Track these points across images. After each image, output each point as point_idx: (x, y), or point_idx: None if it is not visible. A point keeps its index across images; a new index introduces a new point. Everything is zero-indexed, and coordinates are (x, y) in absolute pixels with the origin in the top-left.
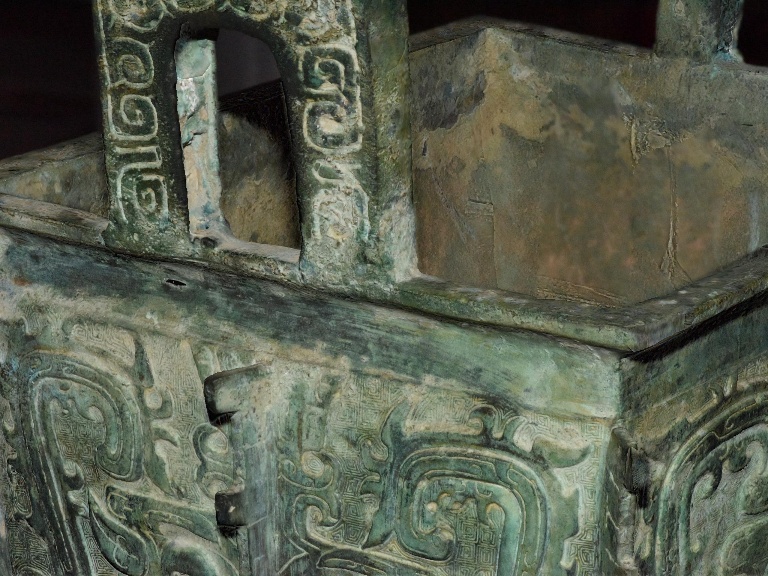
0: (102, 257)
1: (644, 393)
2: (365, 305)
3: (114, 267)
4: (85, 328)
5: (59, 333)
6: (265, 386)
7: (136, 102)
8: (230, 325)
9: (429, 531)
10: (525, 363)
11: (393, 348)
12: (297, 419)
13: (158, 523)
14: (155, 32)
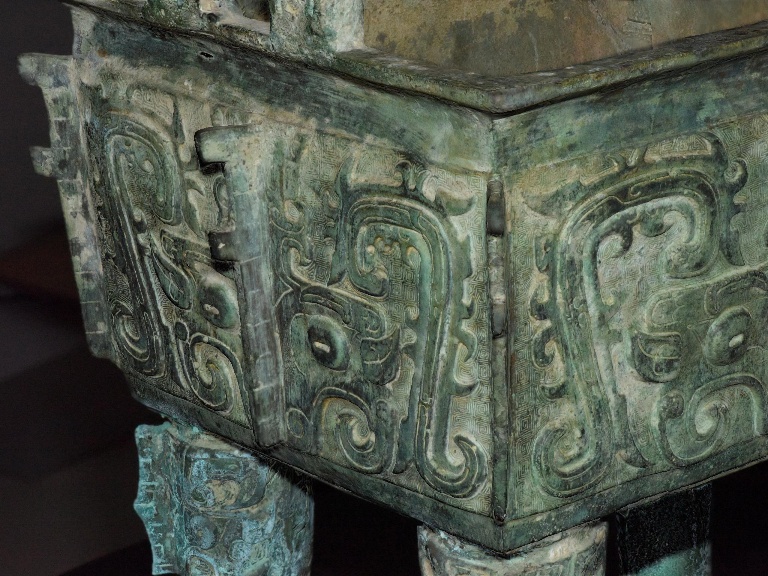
0: (155, 32)
1: (524, 153)
2: (326, 73)
3: (165, 41)
4: (142, 93)
5: (125, 97)
6: (255, 142)
7: None
8: (239, 91)
9: (369, 270)
10: (433, 124)
11: (348, 111)
12: (279, 172)
13: (193, 262)
14: None
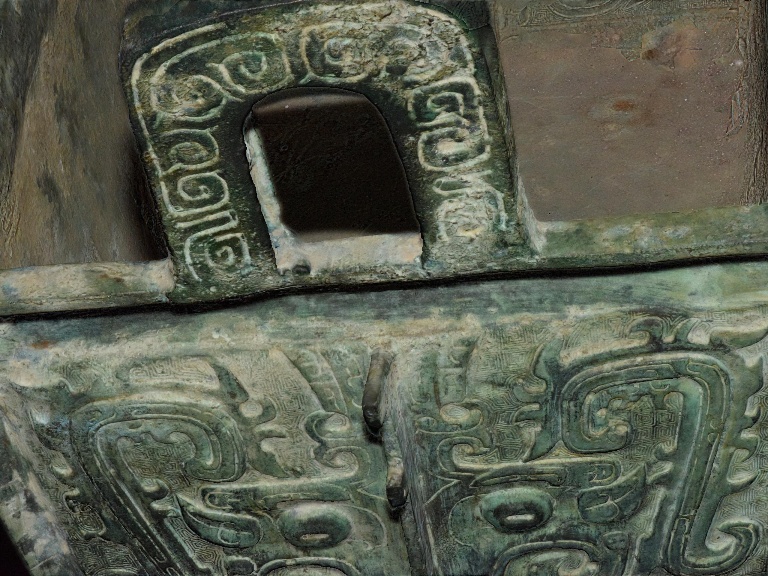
0: None
1: None
2: None
3: None
4: (144, 369)
5: (113, 381)
6: (393, 369)
7: (199, 180)
8: (320, 320)
9: (602, 432)
10: (682, 271)
11: (521, 292)
12: (432, 384)
13: (276, 504)
14: (218, 118)
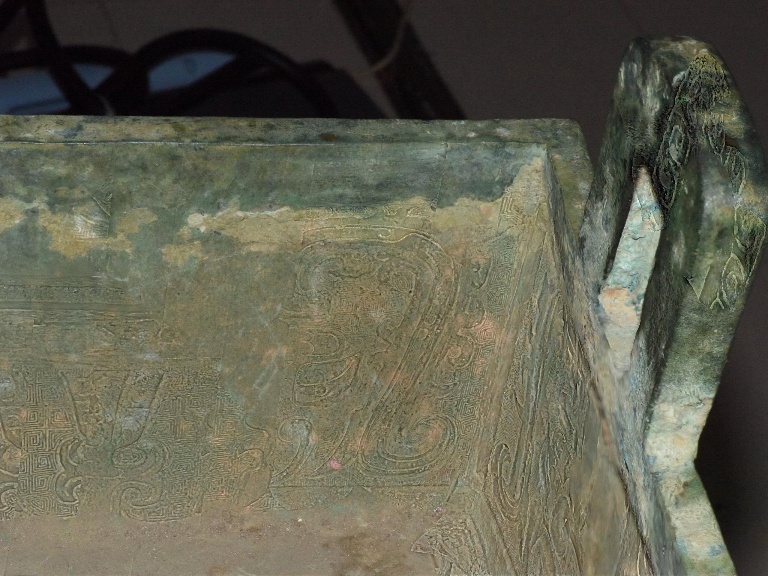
0: None
1: (516, 191)
2: None
3: None
4: None
5: None
6: None
7: None
8: None
9: None
10: None
11: None
12: None
13: None
14: None
